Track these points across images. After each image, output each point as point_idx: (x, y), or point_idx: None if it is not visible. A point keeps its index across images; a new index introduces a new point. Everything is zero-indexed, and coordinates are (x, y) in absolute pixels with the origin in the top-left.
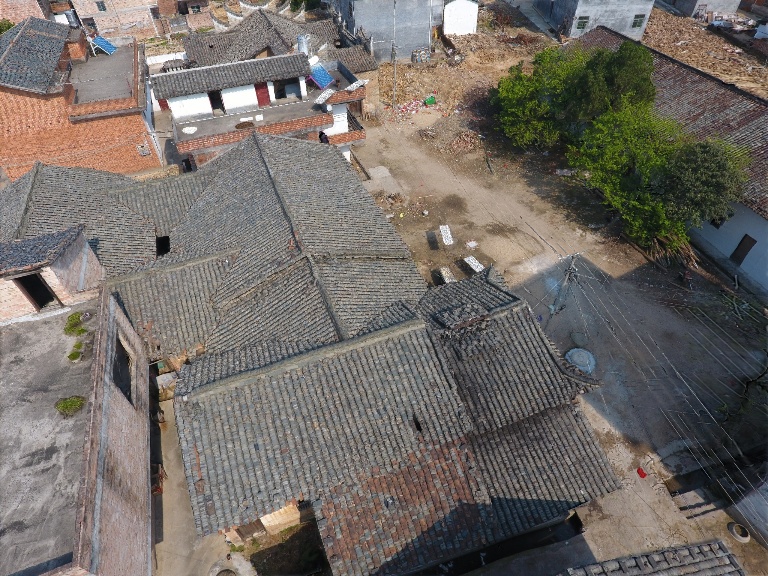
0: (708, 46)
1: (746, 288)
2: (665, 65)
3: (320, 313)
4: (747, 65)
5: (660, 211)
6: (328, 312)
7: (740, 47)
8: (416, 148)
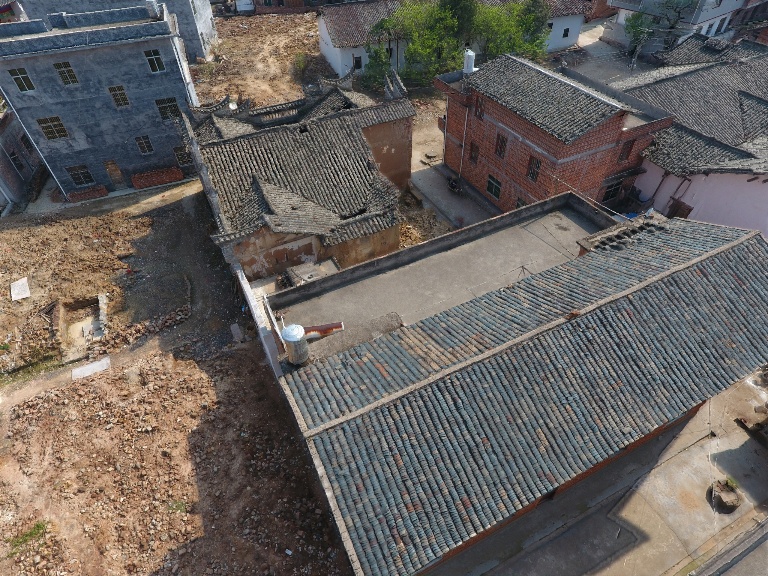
0: (257, 20)
1: (549, 52)
2: (405, 1)
3: (761, 62)
4: (303, 16)
5: (545, 36)
6: (760, 59)
7: (264, 14)
8: (433, 127)
